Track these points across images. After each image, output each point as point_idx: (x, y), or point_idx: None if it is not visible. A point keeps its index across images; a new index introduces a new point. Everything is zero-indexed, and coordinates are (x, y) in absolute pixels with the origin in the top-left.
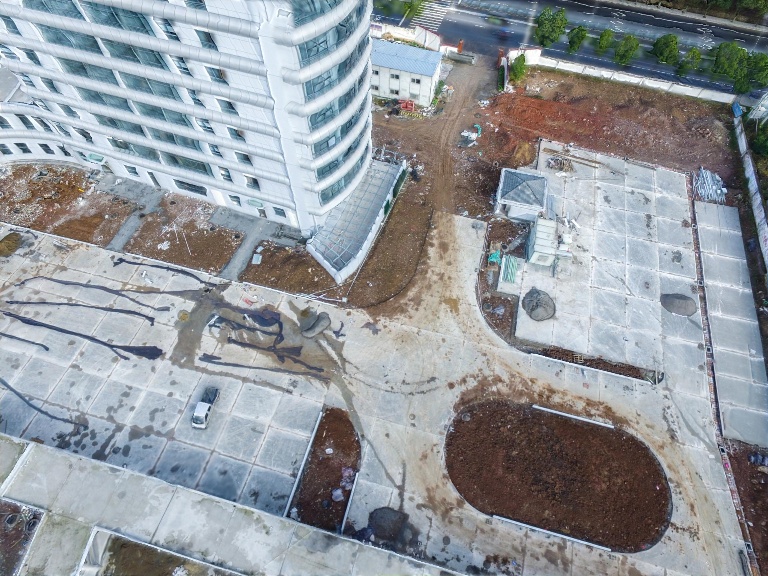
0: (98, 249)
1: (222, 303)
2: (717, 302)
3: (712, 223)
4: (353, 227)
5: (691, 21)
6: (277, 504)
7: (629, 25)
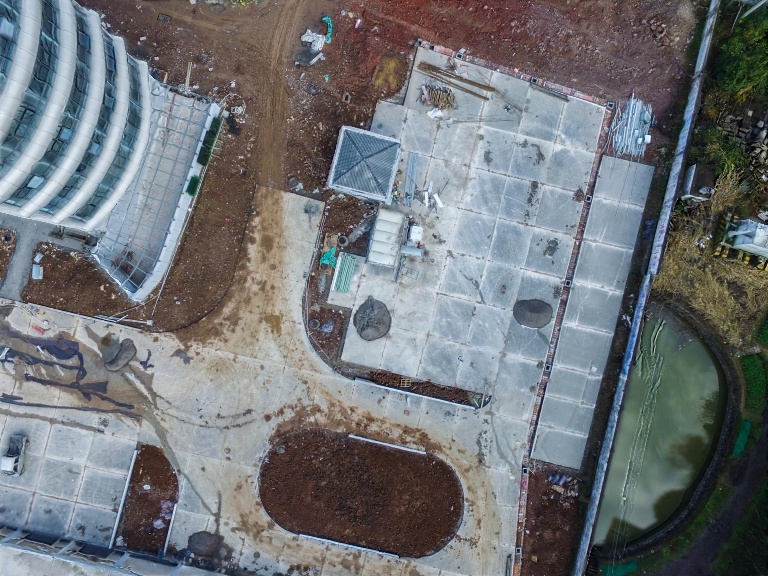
0: None
1: (9, 332)
2: (577, 309)
3: (613, 194)
4: (143, 231)
5: None
6: (103, 535)
7: None
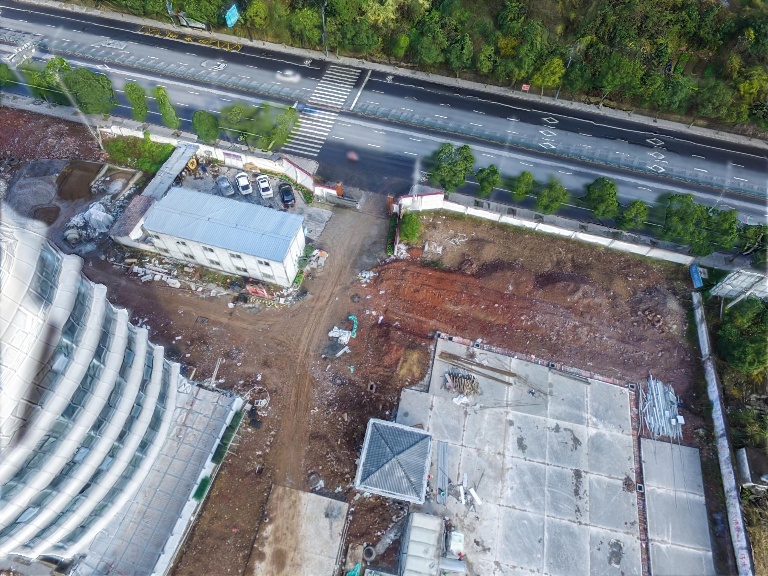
0: None
1: None
2: None
3: (664, 481)
4: (132, 553)
5: (639, 128)
6: None
7: (563, 137)
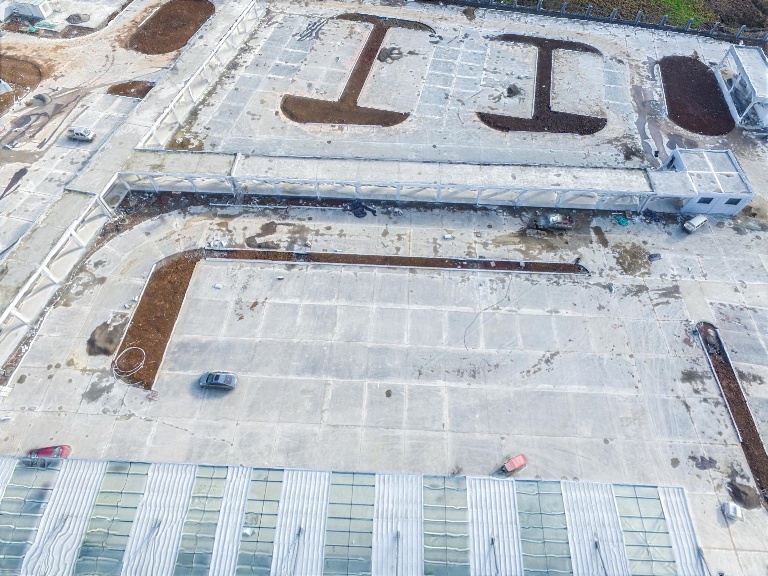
0: None
1: None
2: None
3: None
4: None
5: None
6: None
7: None
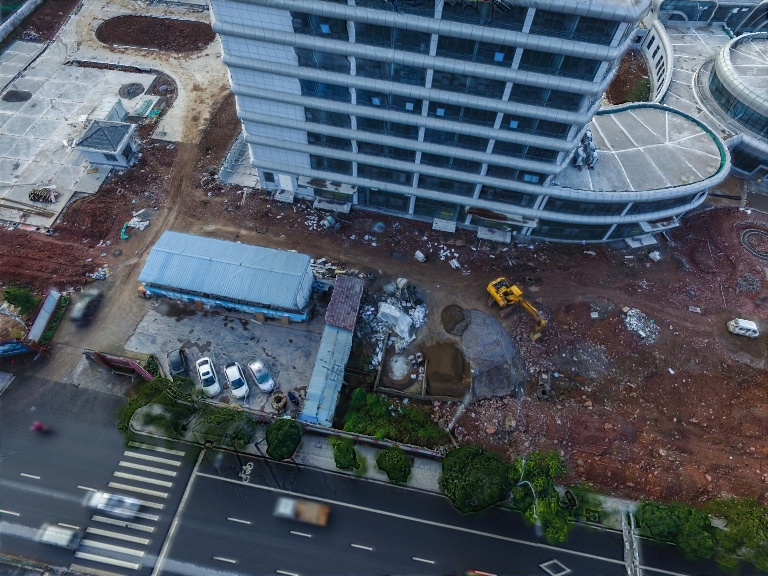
0: None
1: None
2: None
3: None
4: None
5: None
6: None
7: None
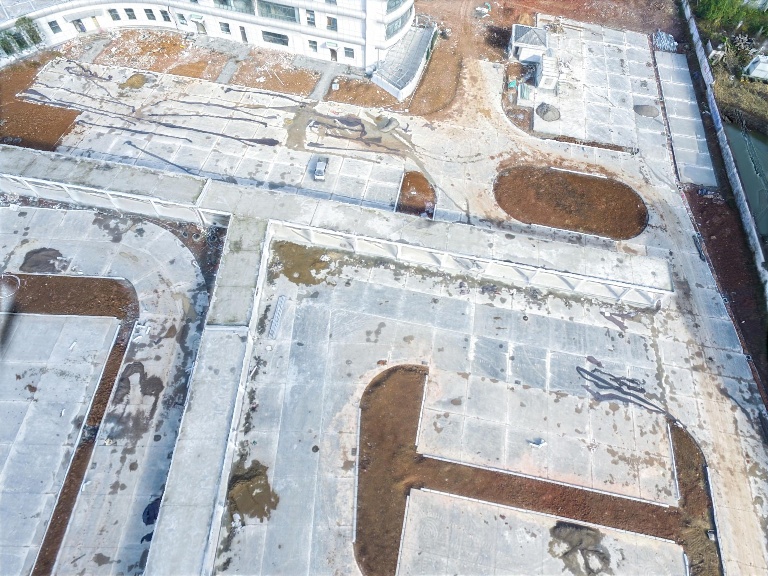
0: (209, 83)
1: (315, 113)
2: (673, 109)
3: (668, 64)
4: (407, 62)
5: None
6: None
7: None
